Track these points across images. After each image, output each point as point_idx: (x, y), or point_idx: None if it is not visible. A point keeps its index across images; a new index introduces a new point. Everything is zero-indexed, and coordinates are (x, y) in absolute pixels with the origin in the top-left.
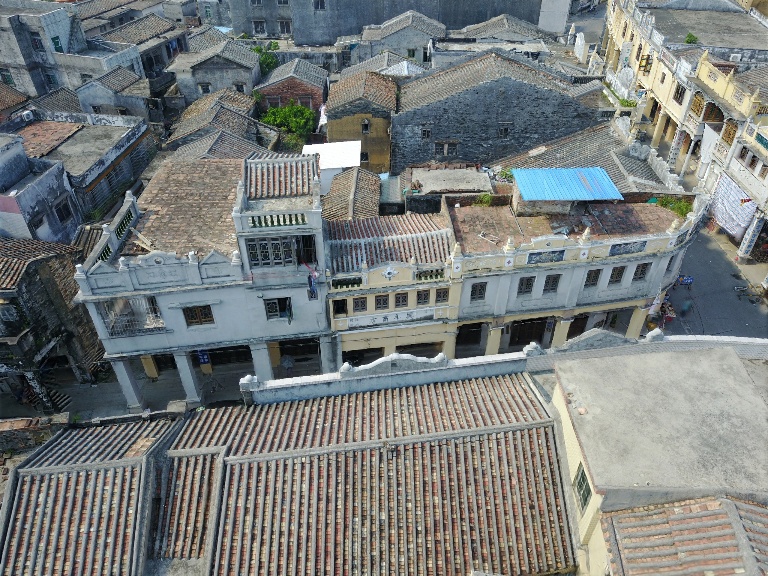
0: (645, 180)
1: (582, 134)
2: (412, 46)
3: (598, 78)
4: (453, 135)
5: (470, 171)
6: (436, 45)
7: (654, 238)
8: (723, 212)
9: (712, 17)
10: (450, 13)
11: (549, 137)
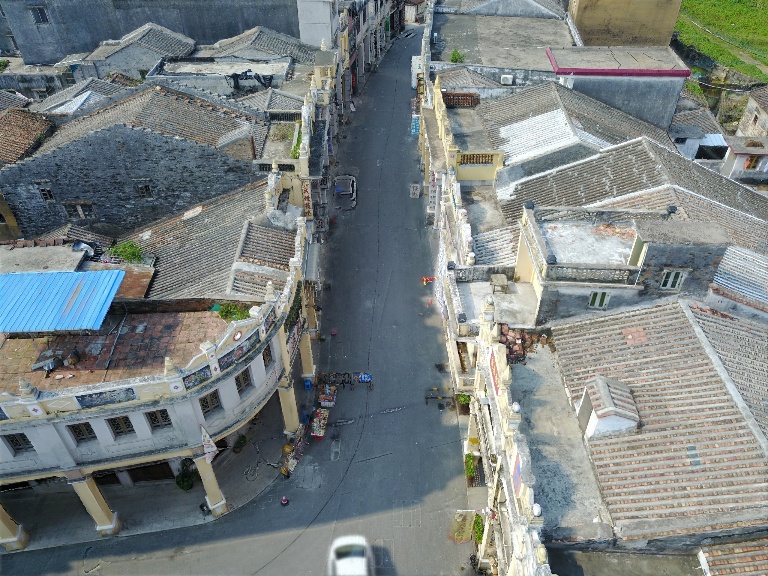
0: (257, 266)
1: (242, 192)
2: (143, 66)
3: (298, 114)
4: (82, 195)
5: (64, 249)
6: (165, 66)
7: (139, 384)
8: (439, 282)
9: (519, 25)
10: (196, 26)
11: (205, 195)
